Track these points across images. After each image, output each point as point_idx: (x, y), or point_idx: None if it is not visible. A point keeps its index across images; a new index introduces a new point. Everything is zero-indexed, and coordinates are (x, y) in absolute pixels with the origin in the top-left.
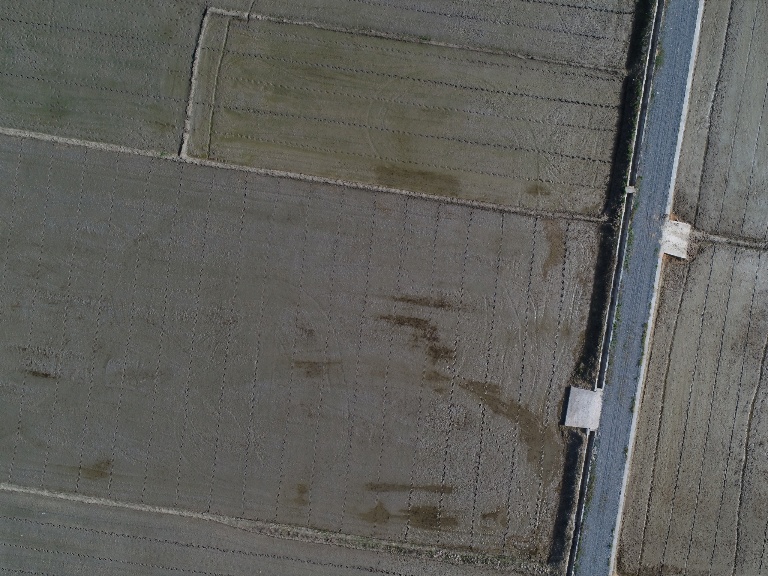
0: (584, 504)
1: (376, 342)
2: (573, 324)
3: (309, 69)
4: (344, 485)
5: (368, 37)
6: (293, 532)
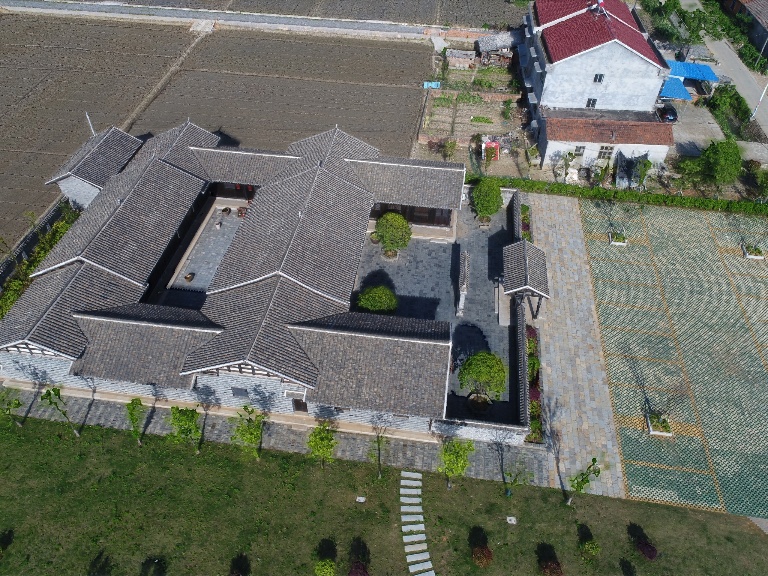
0: None
1: None
2: (165, 5)
3: None
4: None
5: None
6: None
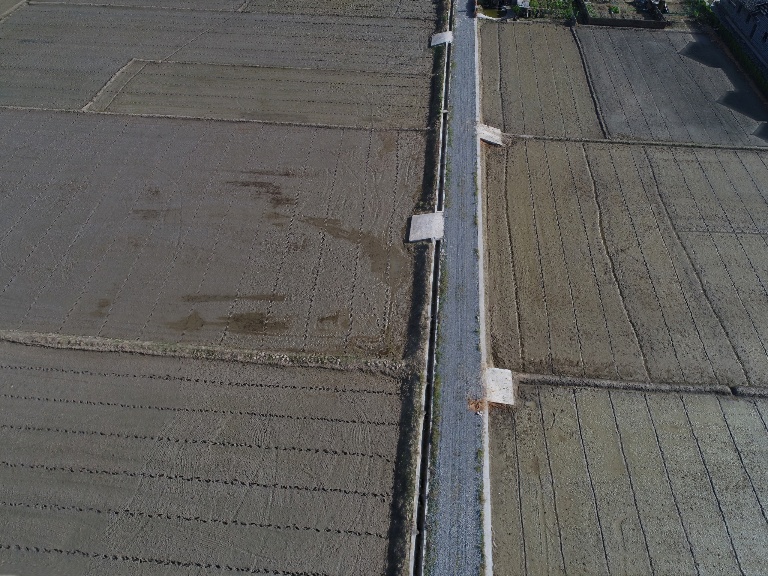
0: (438, 296)
1: (219, 196)
2: (410, 181)
3: (199, 78)
4: (156, 298)
5: (246, 67)
6: (75, 341)
